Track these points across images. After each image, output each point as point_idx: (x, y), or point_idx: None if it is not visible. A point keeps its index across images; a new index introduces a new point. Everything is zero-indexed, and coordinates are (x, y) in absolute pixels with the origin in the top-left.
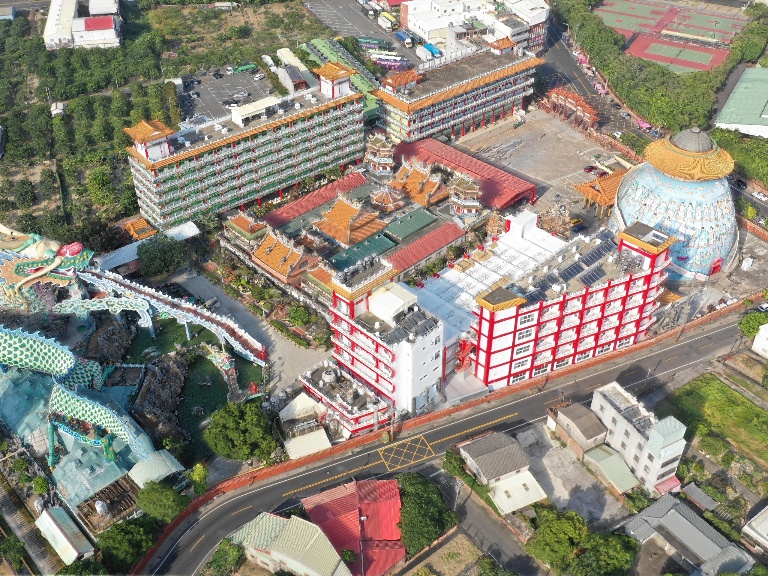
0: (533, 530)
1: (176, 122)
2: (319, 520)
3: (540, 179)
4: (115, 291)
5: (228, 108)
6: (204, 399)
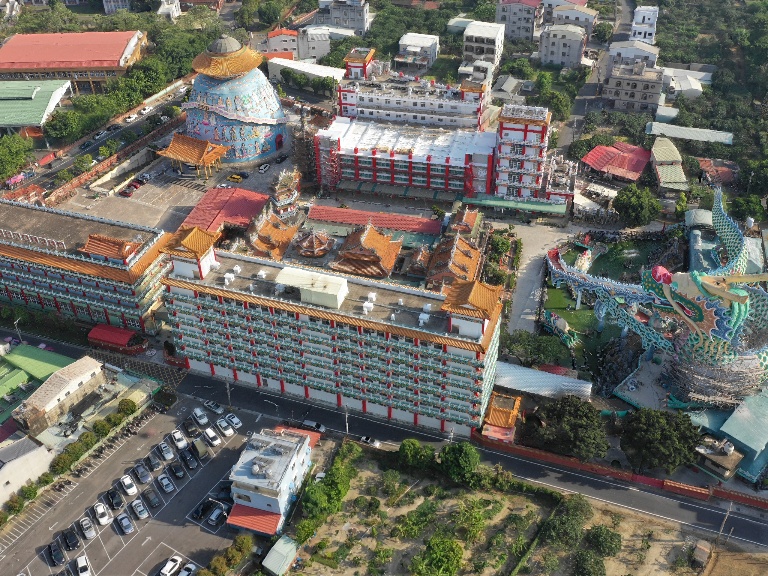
0: (555, 121)
1: (222, 564)
2: (643, 163)
3: (162, 215)
4: None
5: (90, 572)
6: (616, 270)
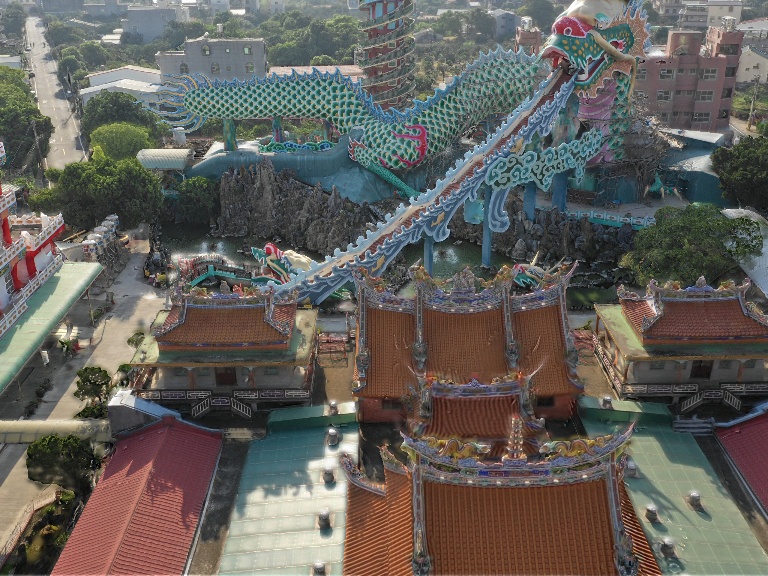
0: None
1: None
2: None
3: None
4: (533, 147)
5: None
6: None
